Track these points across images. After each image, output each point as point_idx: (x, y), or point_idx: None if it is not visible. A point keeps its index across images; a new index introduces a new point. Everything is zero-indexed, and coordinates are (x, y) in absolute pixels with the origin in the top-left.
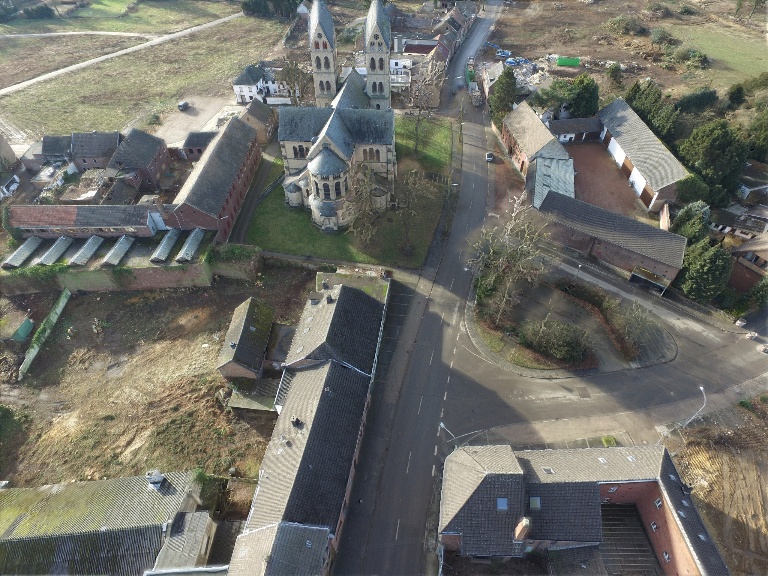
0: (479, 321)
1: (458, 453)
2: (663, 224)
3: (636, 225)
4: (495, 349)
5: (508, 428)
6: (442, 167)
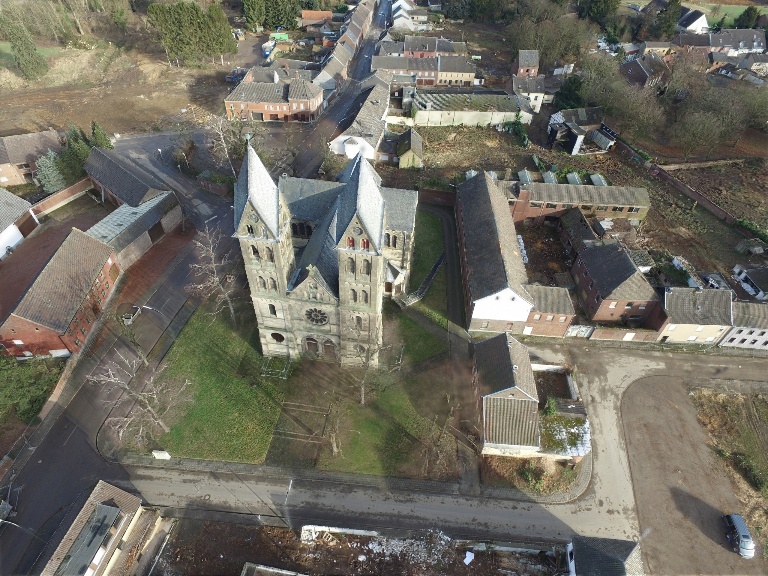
0: (267, 164)
1: (310, 97)
2: (55, 203)
3: (114, 159)
4: (266, 153)
5: (279, 132)
6: (213, 299)
